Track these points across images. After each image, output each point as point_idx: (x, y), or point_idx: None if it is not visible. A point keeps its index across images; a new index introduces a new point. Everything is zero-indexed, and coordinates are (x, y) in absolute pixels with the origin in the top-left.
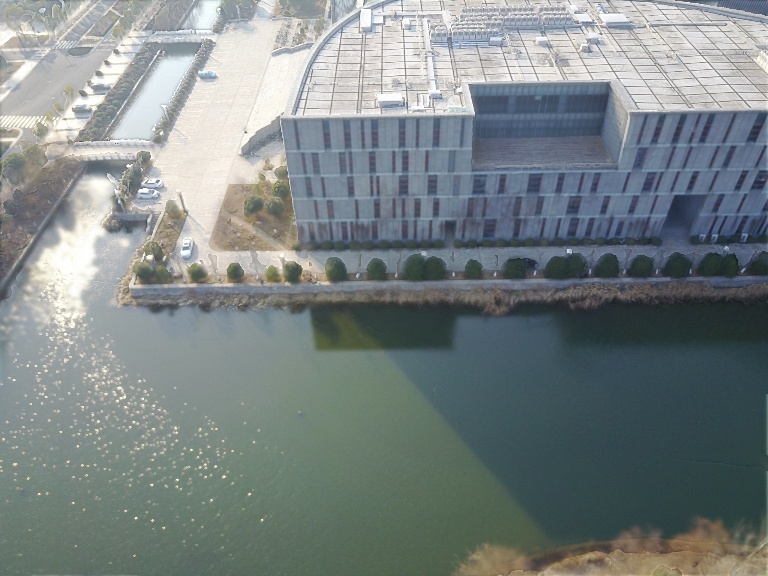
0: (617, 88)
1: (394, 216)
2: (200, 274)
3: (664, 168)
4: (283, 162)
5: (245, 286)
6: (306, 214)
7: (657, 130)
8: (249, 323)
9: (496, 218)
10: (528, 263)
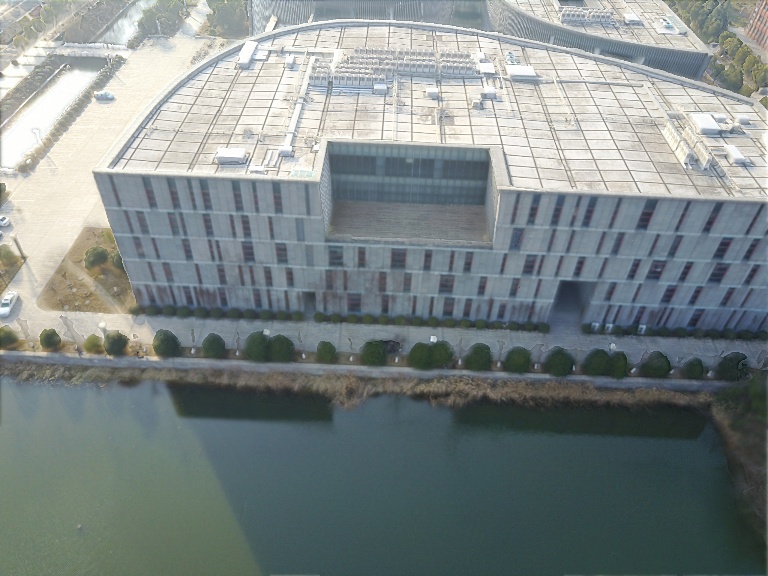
0: (494, 157)
1: (243, 284)
2: (7, 340)
3: (545, 251)
4: None
5: (60, 357)
6: (141, 276)
7: (533, 210)
8: (55, 403)
9: (360, 292)
10: (391, 347)
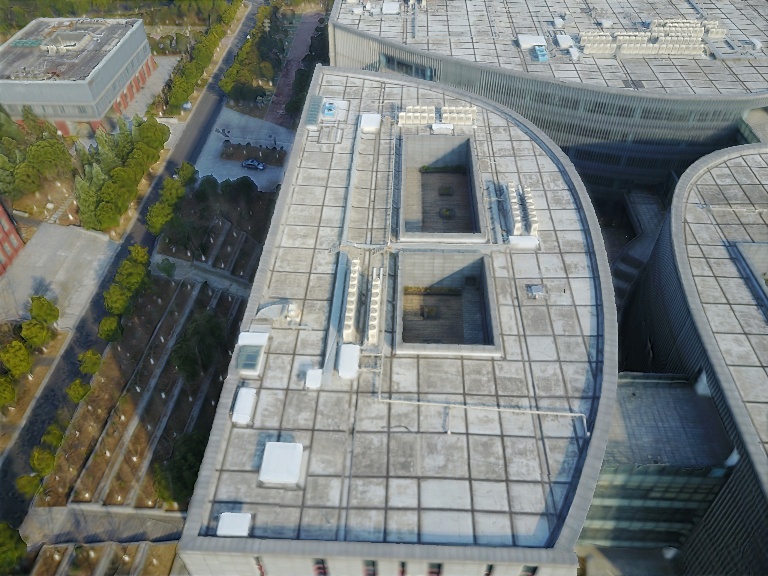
0: None
1: None
2: None
3: None
4: None
5: None
6: None
7: None
8: None
9: None
10: None
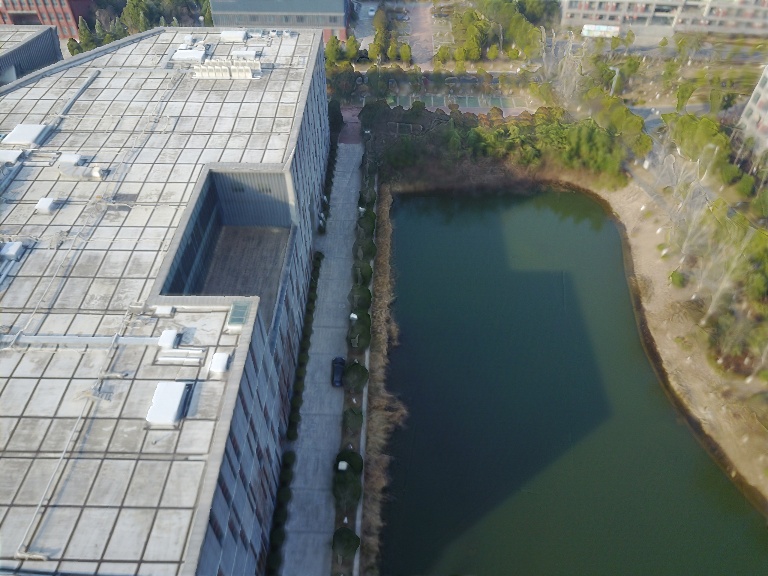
0: (229, 167)
1: (265, 497)
2: None
3: None
4: None
5: None
6: None
7: None
8: None
9: None
10: (342, 365)
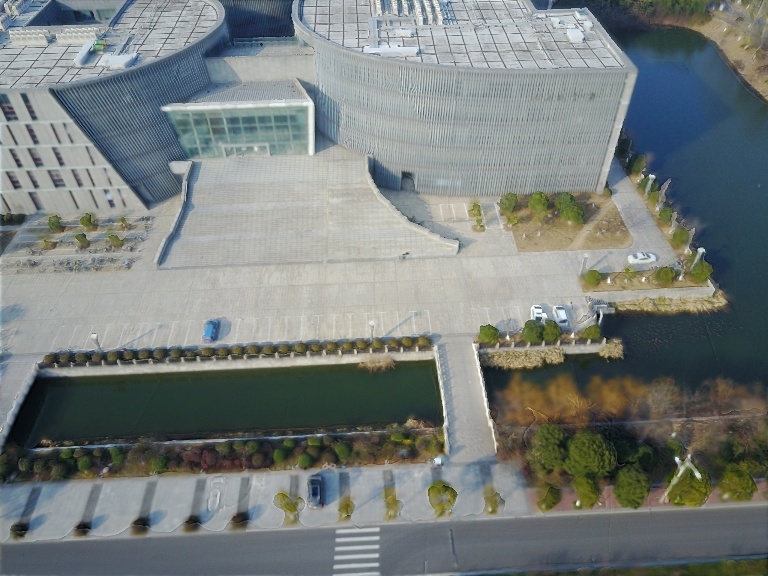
0: None
1: None
2: None
3: None
4: (465, 220)
5: None
6: None
7: None
8: (697, 219)
9: None
10: None
